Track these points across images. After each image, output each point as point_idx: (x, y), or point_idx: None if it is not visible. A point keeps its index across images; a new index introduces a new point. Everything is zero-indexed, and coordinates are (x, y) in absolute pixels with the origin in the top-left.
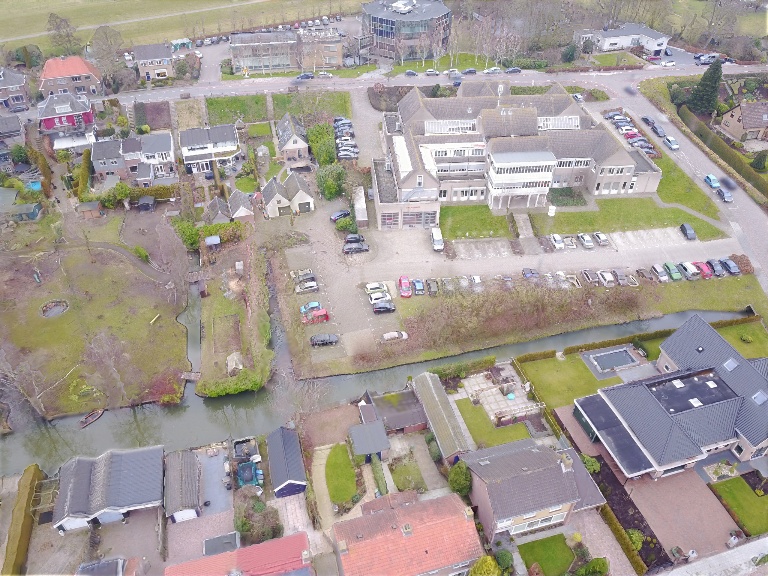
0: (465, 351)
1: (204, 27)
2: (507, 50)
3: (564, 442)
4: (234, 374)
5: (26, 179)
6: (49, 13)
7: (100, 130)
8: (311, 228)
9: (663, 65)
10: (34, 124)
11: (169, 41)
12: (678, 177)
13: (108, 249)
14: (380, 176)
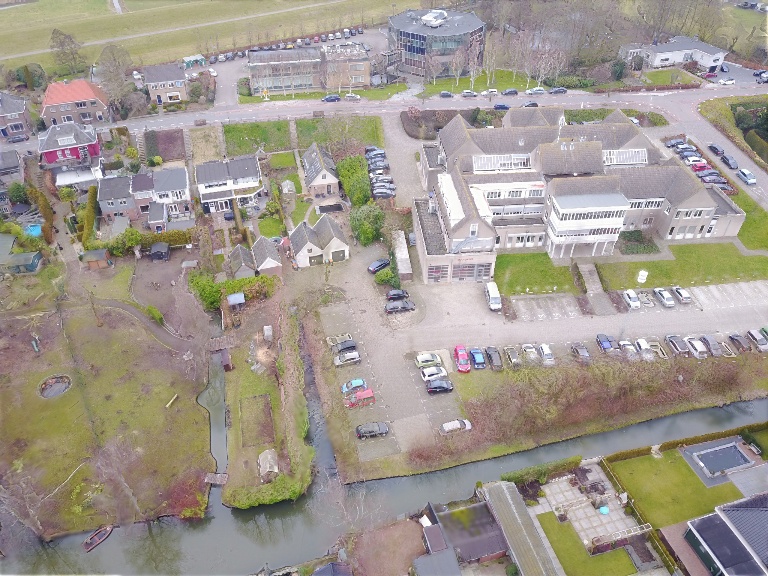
0: (540, 444)
1: None
2: (549, 67)
3: None
4: (268, 478)
5: (25, 222)
6: (52, 27)
7: (107, 163)
8: (347, 281)
9: (722, 83)
10: (34, 157)
11: (180, 57)
12: (760, 218)
13: (117, 308)
14: (424, 220)
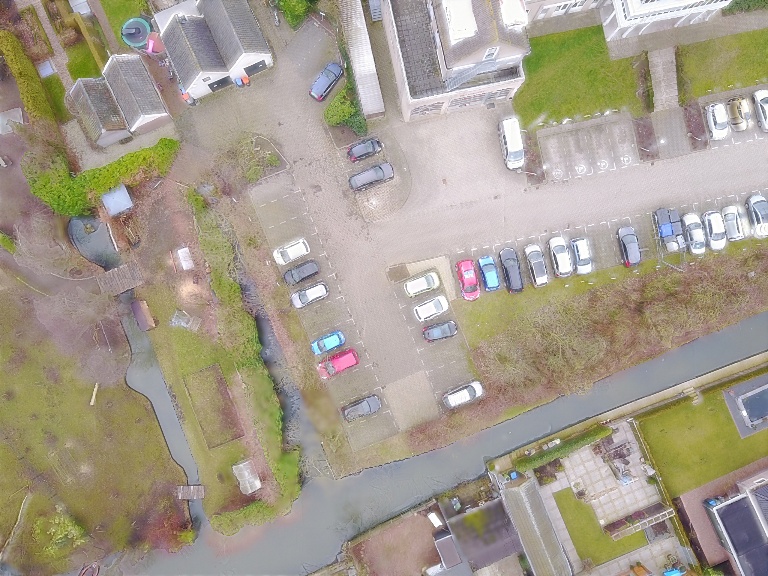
0: (562, 394)
1: None
2: None
3: (690, 556)
4: None
5: None
6: None
7: None
8: (280, 121)
9: None
10: None
11: None
12: None
13: None
14: None
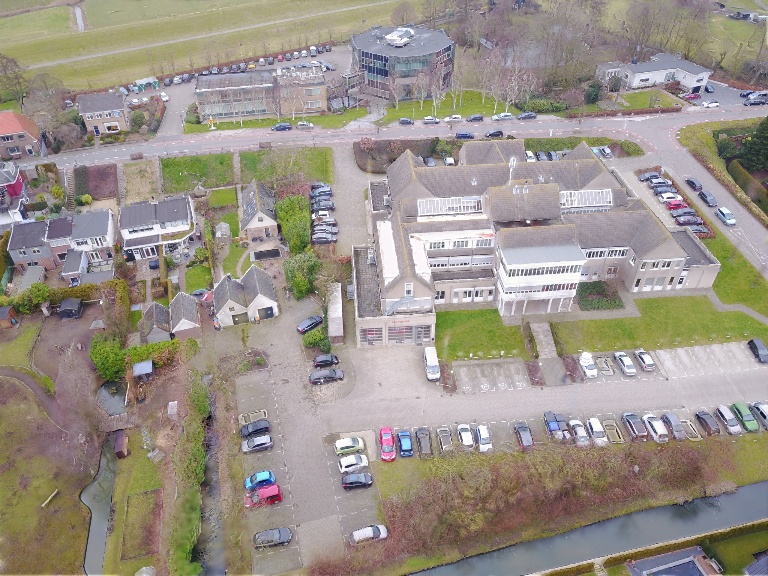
0: (467, 555)
1: (176, 61)
2: (519, 90)
3: None
4: None
5: None
6: (3, 49)
7: (29, 204)
8: (272, 343)
9: (705, 106)
10: None
11: (135, 79)
12: (738, 266)
13: (12, 378)
14: (361, 272)
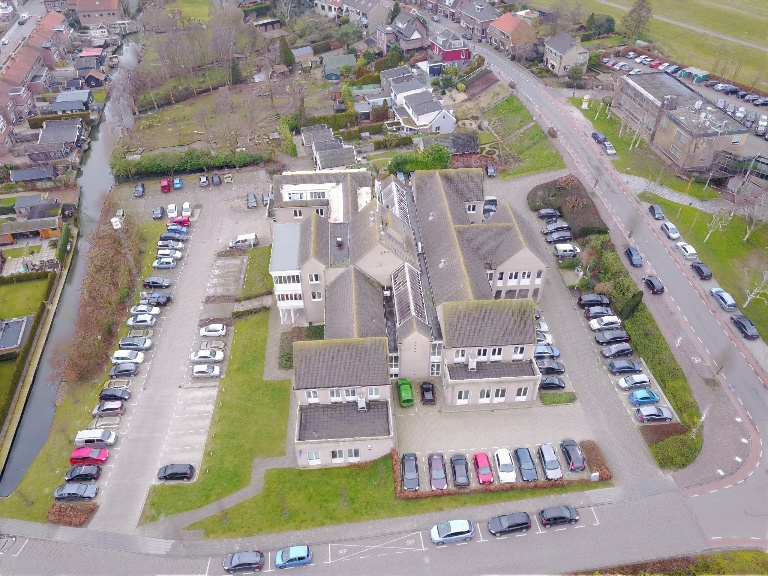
0: None
1: None
2: None
3: None
4: None
5: None
6: (702, 6)
7: None
8: None
9: None
10: None
11: None
12: (330, 508)
13: (287, 109)
14: None
